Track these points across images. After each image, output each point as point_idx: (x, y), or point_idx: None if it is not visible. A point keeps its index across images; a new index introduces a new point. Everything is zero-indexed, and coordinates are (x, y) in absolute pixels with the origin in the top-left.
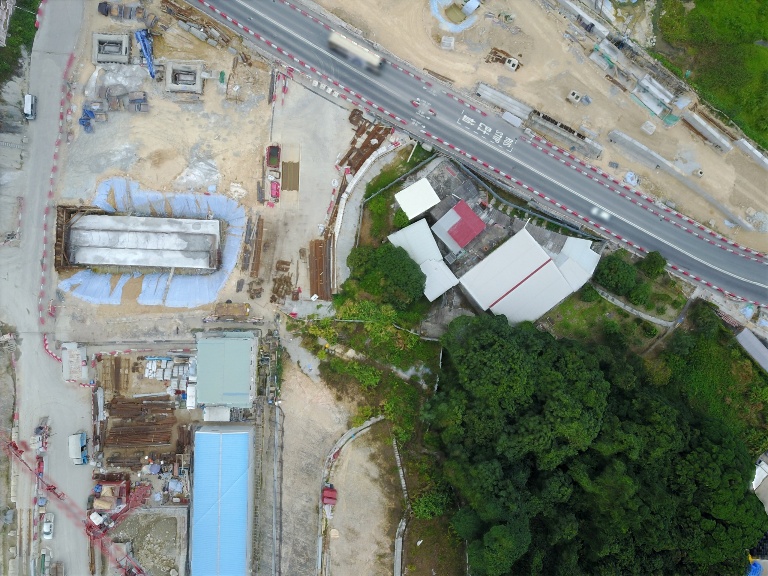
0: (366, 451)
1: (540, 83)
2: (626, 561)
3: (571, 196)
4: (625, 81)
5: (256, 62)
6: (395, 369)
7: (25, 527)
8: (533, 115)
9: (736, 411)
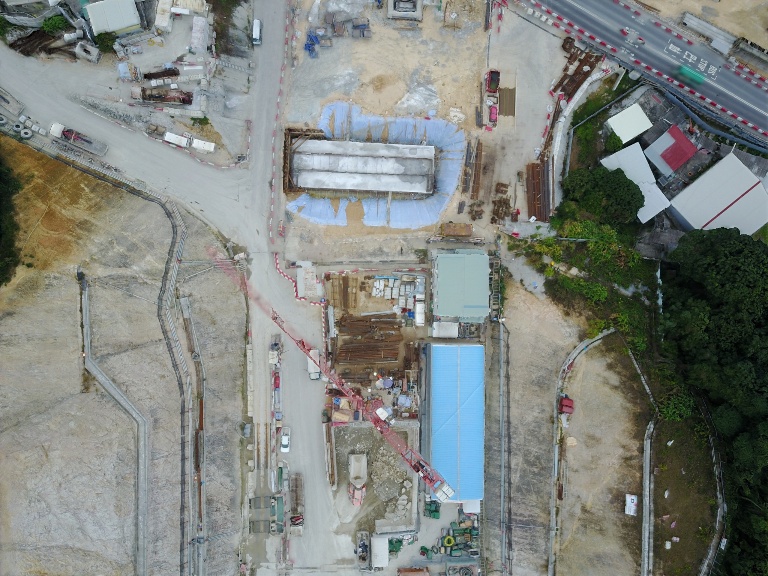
0: (602, 361)
1: (742, 13)
2: None
3: None
4: None
5: None
6: (617, 286)
7: (262, 441)
8: (741, 42)
9: None
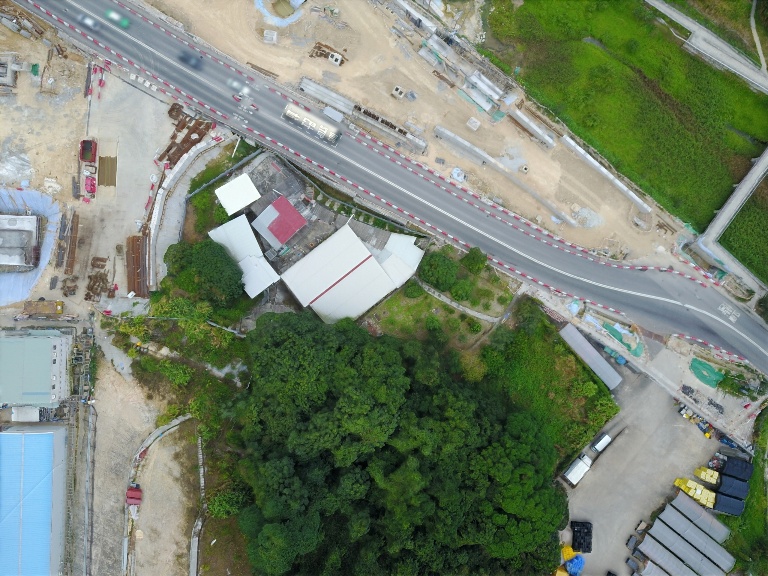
0: (171, 450)
1: (365, 78)
2: (425, 557)
3: (397, 192)
4: (455, 77)
5: (72, 54)
6: (210, 367)
7: None
8: (354, 110)
9: (559, 406)
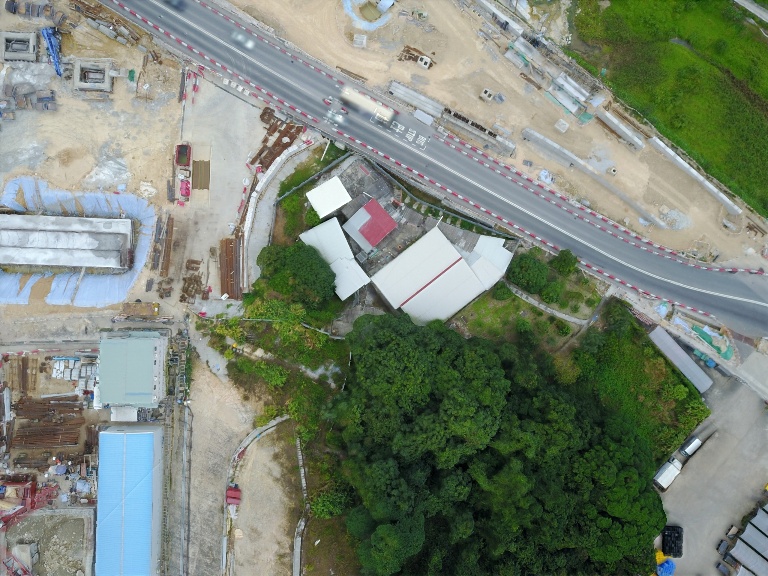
0: (270, 451)
1: (453, 81)
2: (526, 559)
3: (485, 194)
4: (541, 79)
5: (166, 60)
6: (304, 368)
7: None
8: (444, 113)
9: (649, 409)
